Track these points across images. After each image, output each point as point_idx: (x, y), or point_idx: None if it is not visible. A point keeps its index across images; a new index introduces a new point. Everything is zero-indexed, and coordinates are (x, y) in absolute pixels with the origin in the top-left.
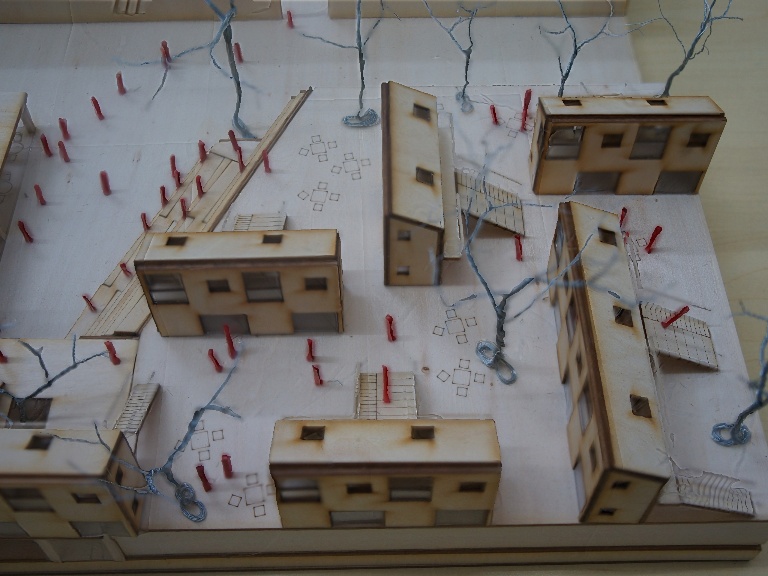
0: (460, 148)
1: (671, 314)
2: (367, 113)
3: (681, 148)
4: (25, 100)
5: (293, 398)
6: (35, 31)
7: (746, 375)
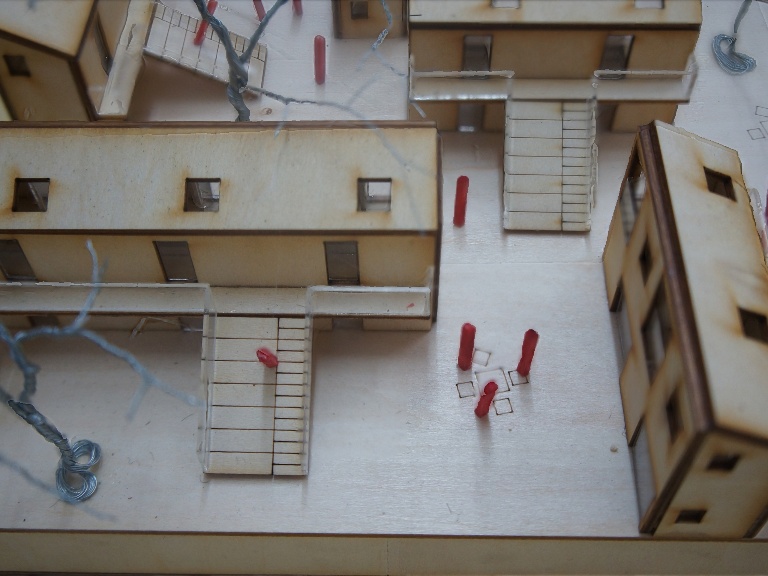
0: None
1: (302, 386)
2: (743, 56)
3: (664, 399)
4: None
5: (246, 0)
6: None
7: (190, 525)
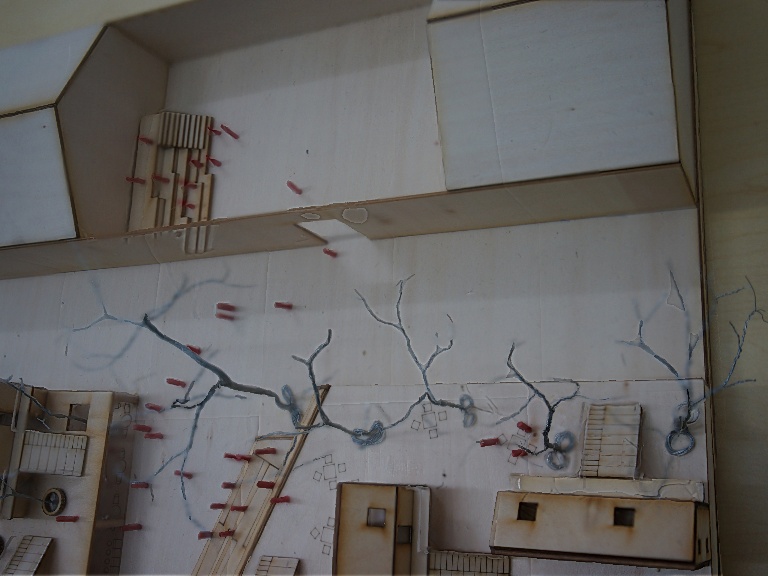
0: (458, 479)
1: None
2: (372, 428)
3: None
4: (113, 400)
5: None
6: (134, 275)
7: None
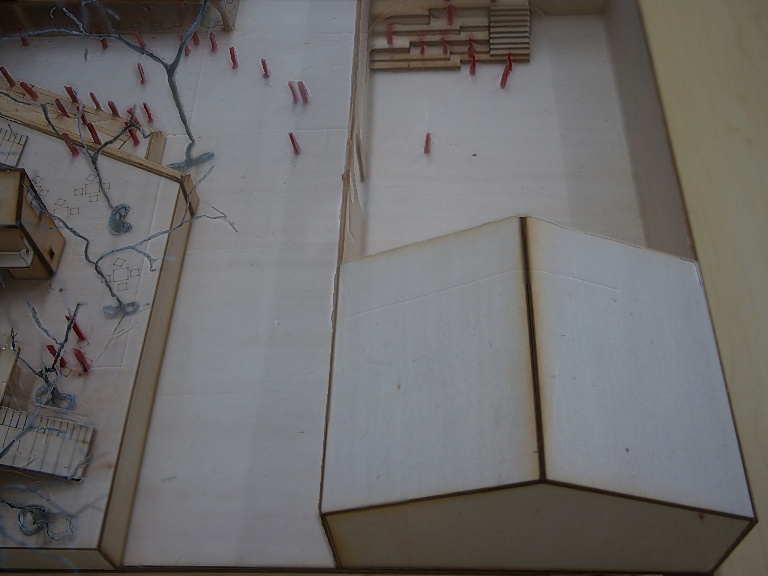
0: (54, 302)
1: None
2: (124, 222)
3: None
4: (213, 1)
5: None
6: None
7: None
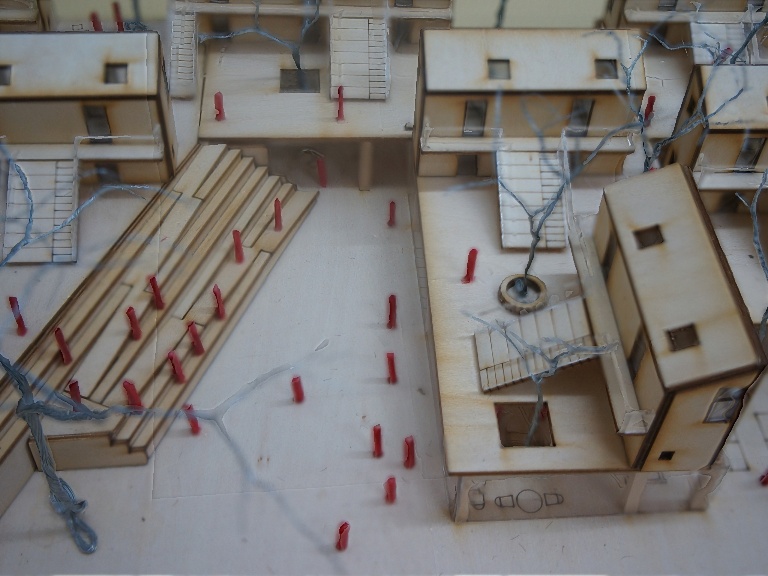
0: None
1: None
2: None
3: None
4: None
5: None
6: None
7: None
